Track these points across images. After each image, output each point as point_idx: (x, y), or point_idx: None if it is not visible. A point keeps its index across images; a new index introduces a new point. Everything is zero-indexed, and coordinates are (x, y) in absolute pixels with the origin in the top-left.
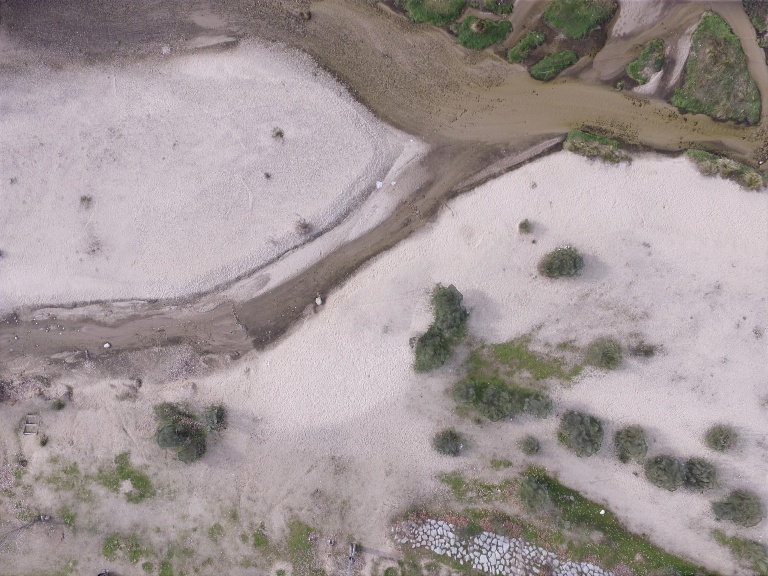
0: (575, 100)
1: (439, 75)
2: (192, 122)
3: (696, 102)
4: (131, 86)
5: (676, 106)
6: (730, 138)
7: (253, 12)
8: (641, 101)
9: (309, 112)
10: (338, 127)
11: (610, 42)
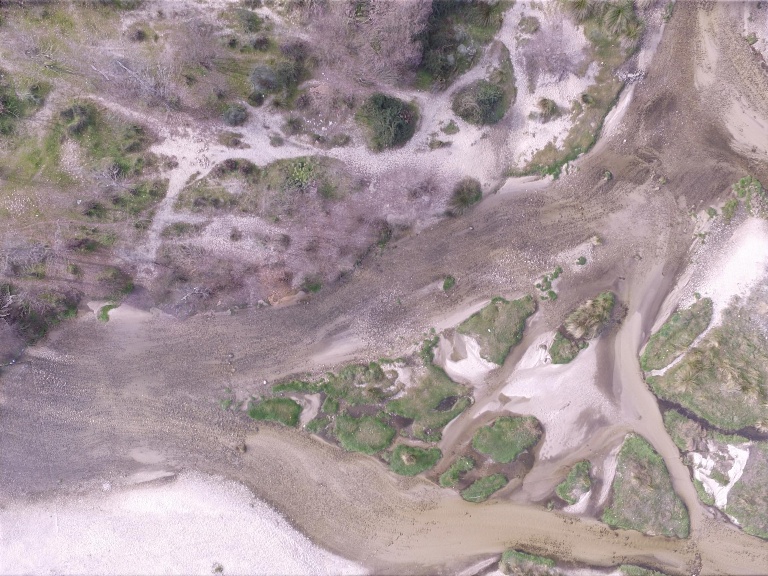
0: (508, 520)
1: (373, 501)
2: (133, 561)
3: (625, 521)
4: (73, 525)
5: (606, 523)
6: (662, 552)
7: (190, 447)
8: (572, 519)
9: (247, 547)
10: (276, 560)
11: (538, 464)
